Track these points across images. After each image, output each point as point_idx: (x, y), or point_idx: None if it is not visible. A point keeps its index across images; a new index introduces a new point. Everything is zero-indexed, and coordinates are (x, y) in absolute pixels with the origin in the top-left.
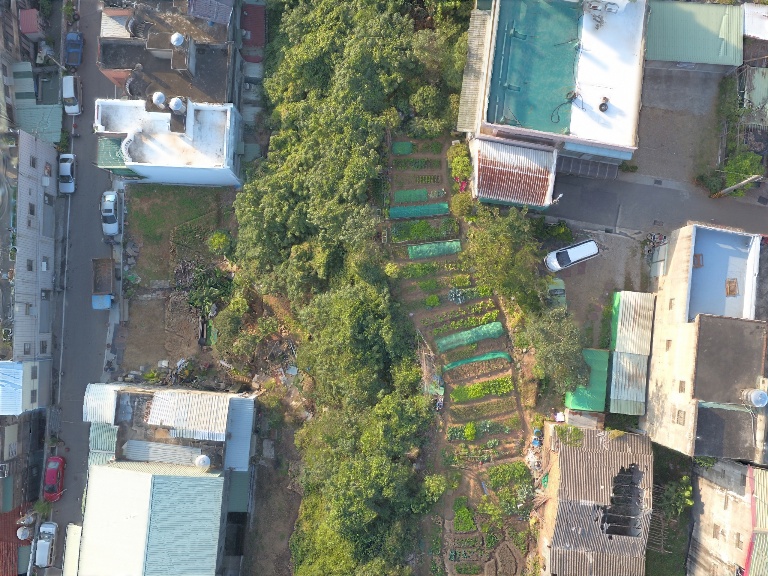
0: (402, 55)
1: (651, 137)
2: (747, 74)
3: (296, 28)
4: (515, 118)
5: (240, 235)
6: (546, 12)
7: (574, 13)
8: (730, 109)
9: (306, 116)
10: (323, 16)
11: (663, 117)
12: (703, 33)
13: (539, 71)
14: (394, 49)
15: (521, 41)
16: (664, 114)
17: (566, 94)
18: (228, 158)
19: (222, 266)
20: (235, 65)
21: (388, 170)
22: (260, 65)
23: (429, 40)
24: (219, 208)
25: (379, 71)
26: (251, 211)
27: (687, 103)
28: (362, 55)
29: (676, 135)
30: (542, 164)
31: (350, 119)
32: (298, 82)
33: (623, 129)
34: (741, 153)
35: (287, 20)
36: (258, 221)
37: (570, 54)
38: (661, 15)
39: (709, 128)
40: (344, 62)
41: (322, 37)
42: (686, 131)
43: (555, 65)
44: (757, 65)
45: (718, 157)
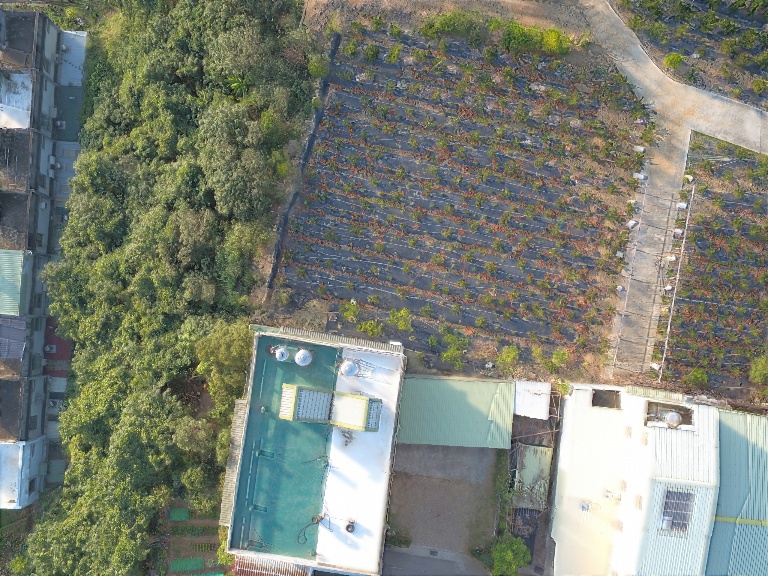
0: (168, 441)
1: (427, 507)
2: (519, 452)
3: (83, 375)
4: (261, 540)
5: (36, 568)
6: (294, 429)
7: (323, 429)
8: (501, 489)
9: (85, 479)
10: (105, 371)
11: (440, 486)
12: (472, 415)
13: (286, 490)
14: (160, 434)
15: (269, 459)
16: (441, 483)
17: (312, 516)
18: (22, 494)
19: (32, 575)
20: (31, 397)
21: (165, 538)
22: (65, 380)
23: (192, 431)
24: (31, 514)
25: (148, 450)
26: (40, 557)
27: (464, 472)
28: (128, 439)
29: (453, 505)
30: (300, 565)
31: (118, 500)
32: (81, 436)
33: (370, 549)
34: (507, 541)
35: (77, 361)
36: (47, 567)
37: (318, 472)
38: (431, 395)
39: (486, 498)
40: (114, 440)
41: (101, 398)
42: (463, 501)
43: (303, 484)
44: (530, 441)
45: (494, 528)
